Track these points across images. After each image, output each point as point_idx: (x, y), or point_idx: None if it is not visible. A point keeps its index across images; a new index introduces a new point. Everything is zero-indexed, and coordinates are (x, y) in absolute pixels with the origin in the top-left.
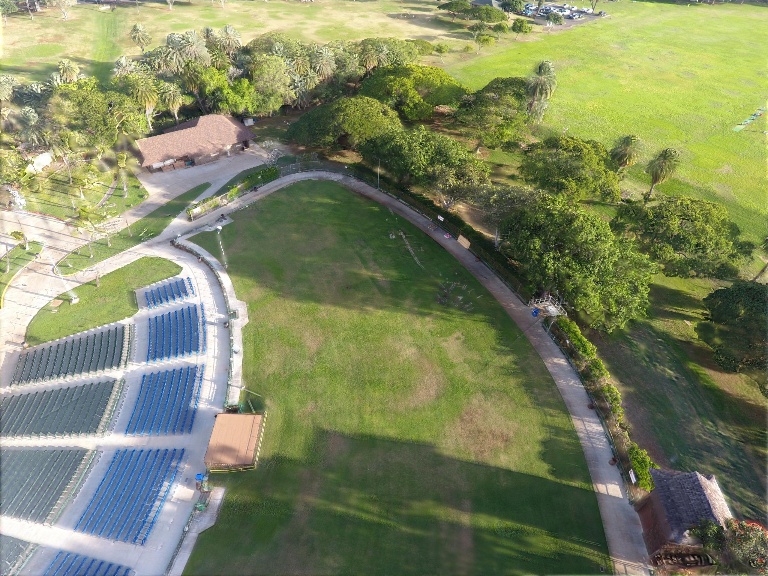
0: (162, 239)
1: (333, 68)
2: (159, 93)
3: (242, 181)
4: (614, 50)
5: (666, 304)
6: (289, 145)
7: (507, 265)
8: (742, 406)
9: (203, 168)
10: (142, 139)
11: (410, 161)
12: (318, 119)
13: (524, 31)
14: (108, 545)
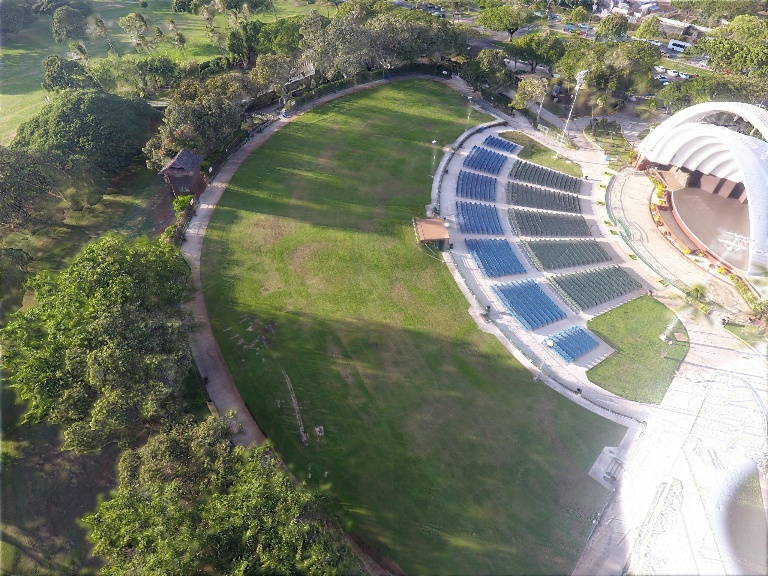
0: (669, 438)
1: None
2: None
3: None
4: None
5: None
6: None
7: None
8: None
9: None
10: None
11: None
12: None
13: None
14: None
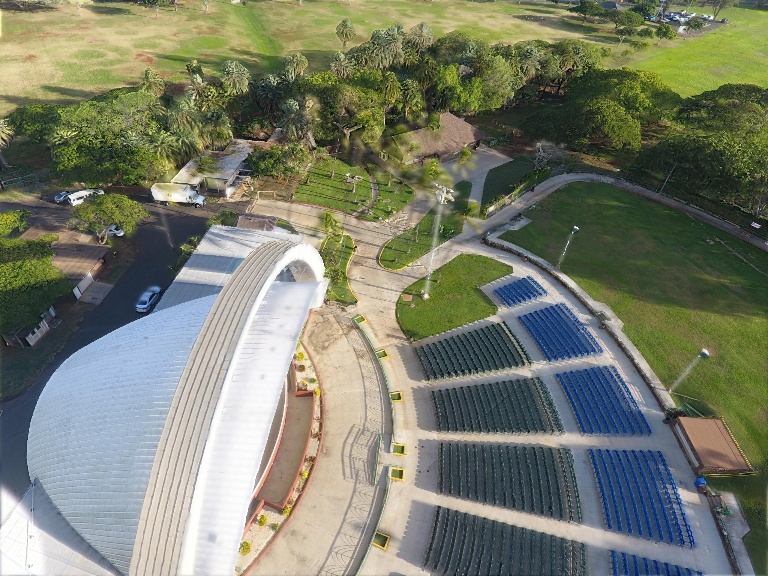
0: (468, 236)
1: (534, 69)
2: (402, 89)
3: (522, 181)
4: (762, 58)
5: None
6: (514, 145)
7: None
8: None
9: (448, 166)
10: (398, 135)
11: (732, 167)
12: (564, 120)
13: (669, 36)
14: (652, 546)
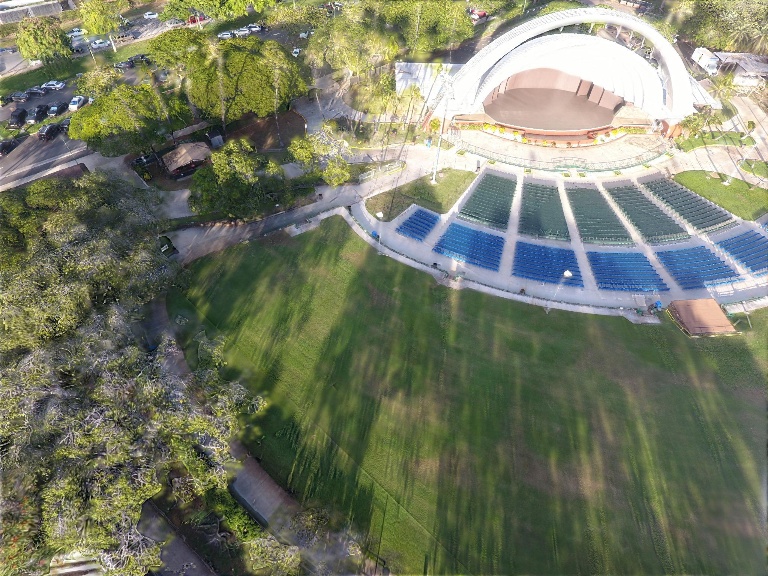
0: None
1: None
2: None
3: None
4: None
5: None
6: None
7: None
8: None
9: None
10: None
11: None
12: None
13: None
14: (589, 272)
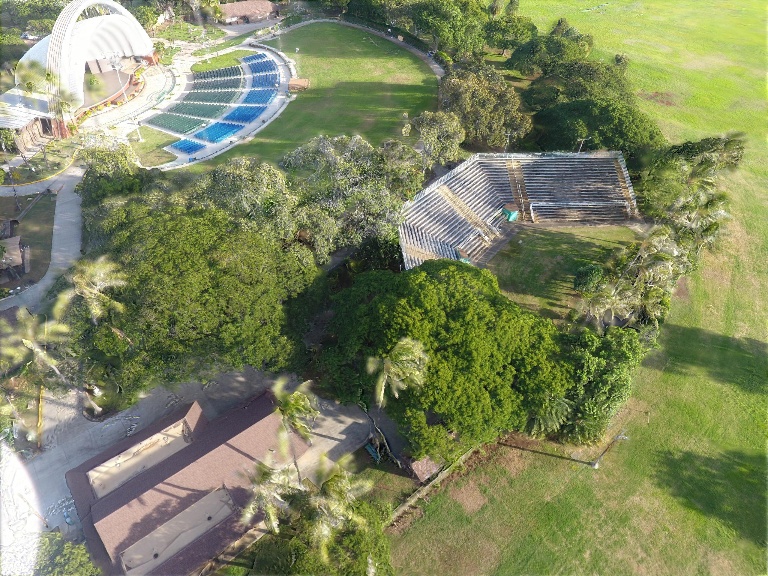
0: (243, 45)
1: None
2: None
3: (282, 21)
4: None
5: (501, 66)
6: None
7: (419, 40)
8: (519, 89)
9: (254, 24)
10: (220, 5)
11: None
12: None
13: None
14: (257, 105)
